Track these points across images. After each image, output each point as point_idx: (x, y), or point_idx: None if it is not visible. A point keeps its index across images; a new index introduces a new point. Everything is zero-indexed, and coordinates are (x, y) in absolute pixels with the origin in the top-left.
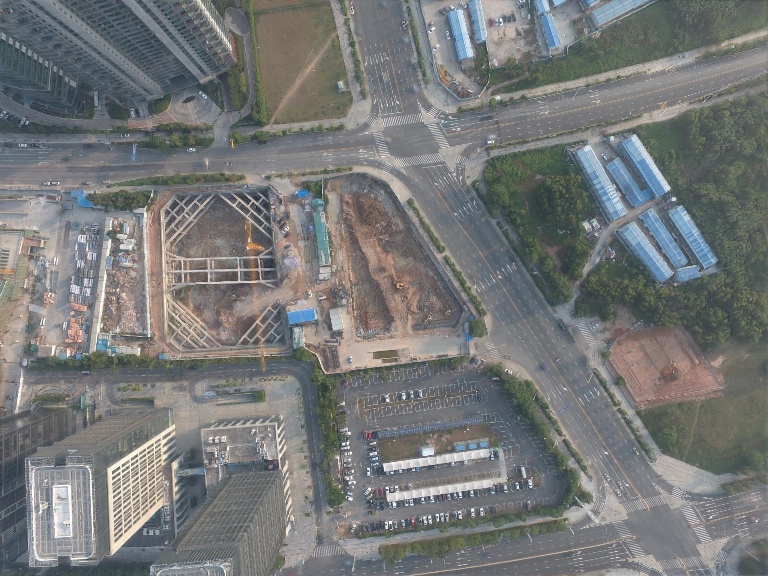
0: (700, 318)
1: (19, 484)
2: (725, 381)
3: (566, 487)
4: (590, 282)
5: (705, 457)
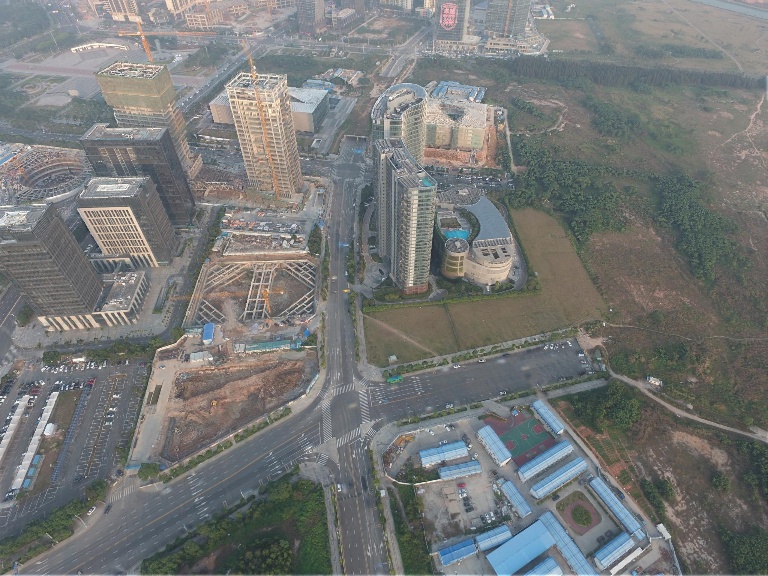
0: None
1: None
2: None
3: None
4: None
5: None
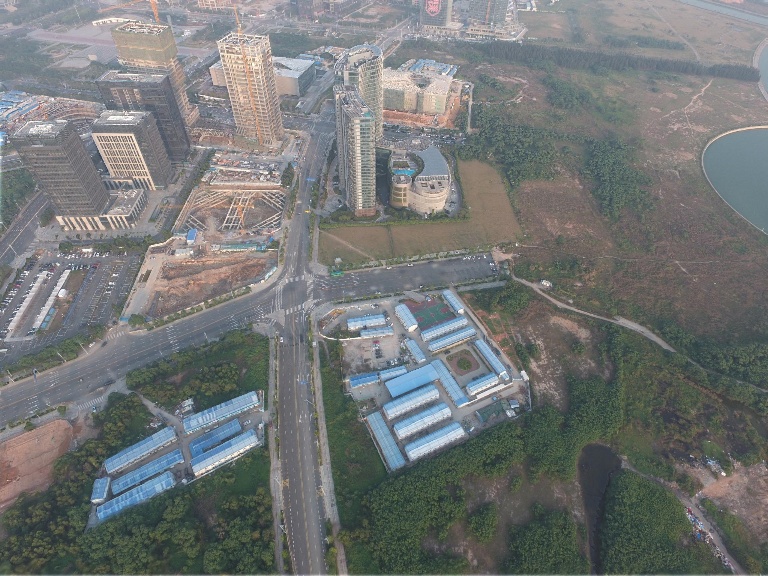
0: (47, 495)
1: None
2: None
3: None
4: (135, 396)
5: None
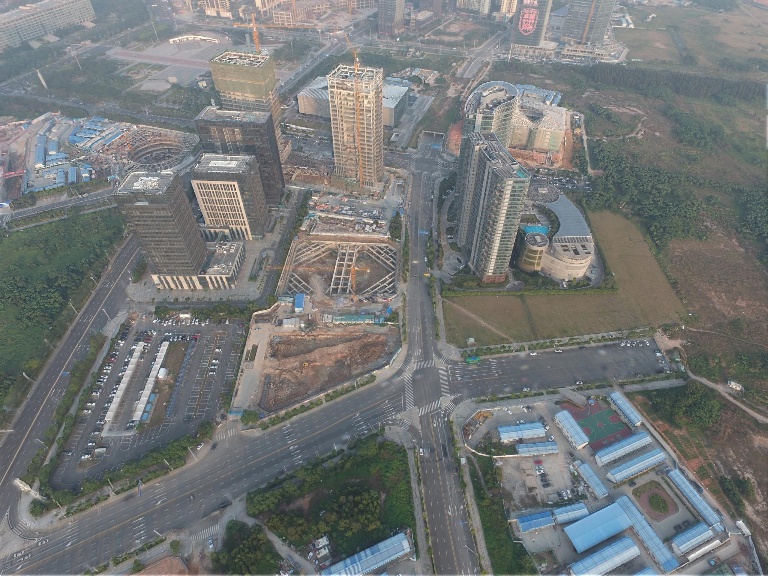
0: None
1: None
2: None
3: None
4: (260, 531)
5: None
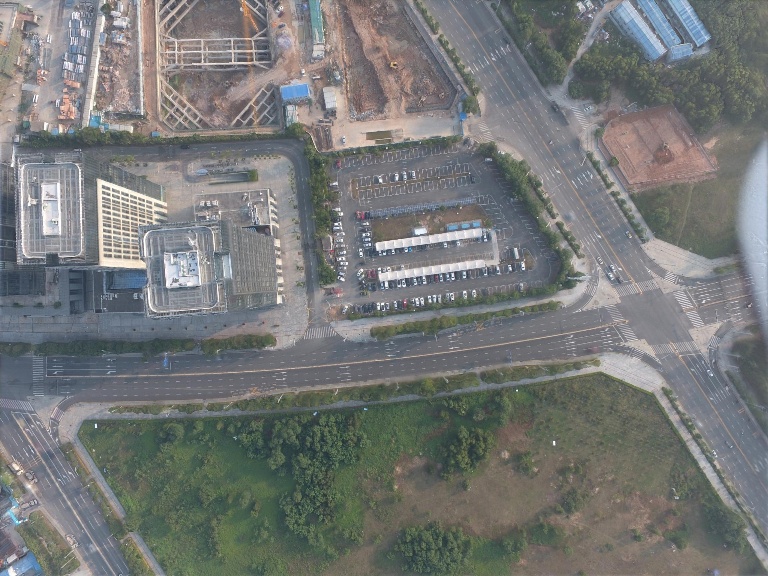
0: (693, 93)
1: (9, 223)
2: (718, 163)
3: (559, 270)
4: (583, 58)
5: (698, 240)
